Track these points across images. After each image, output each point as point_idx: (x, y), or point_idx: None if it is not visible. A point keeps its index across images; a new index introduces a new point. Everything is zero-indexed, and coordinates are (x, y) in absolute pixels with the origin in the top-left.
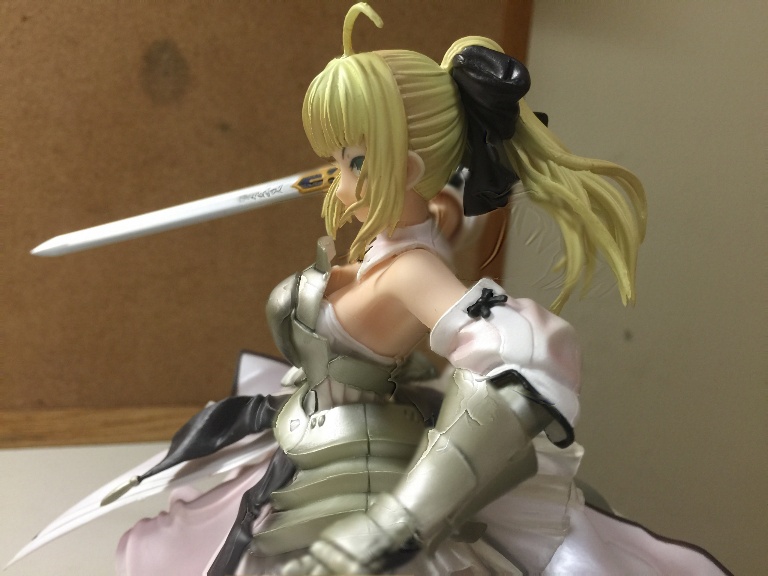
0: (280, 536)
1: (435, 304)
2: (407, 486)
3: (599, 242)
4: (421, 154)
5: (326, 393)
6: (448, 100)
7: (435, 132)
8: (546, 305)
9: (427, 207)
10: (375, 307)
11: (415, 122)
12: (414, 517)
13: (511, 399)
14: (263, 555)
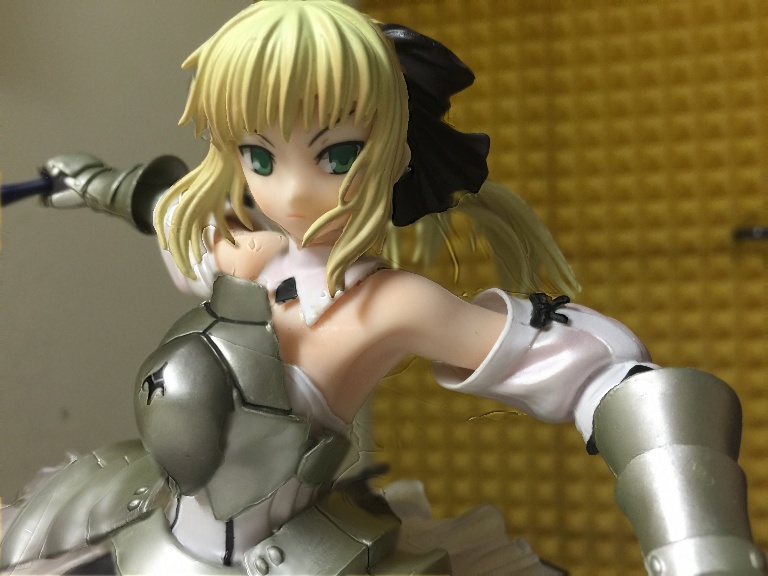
0: None
1: (473, 326)
2: None
3: (539, 240)
4: None
5: (260, 513)
6: None
7: None
8: None
9: None
10: (361, 354)
11: None
12: None
13: None
14: None
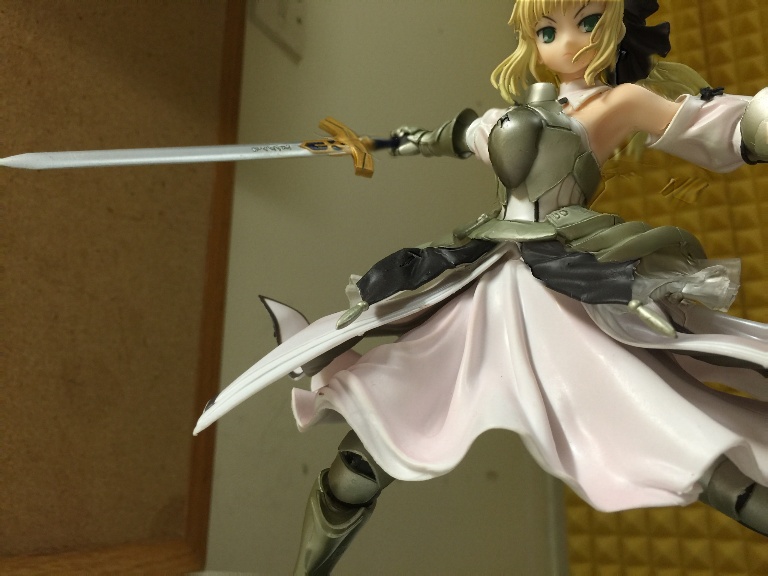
0: (633, 245)
1: (667, 103)
2: None
3: None
4: None
5: (553, 198)
6: None
7: None
8: None
9: None
10: (604, 119)
11: None
12: (690, 241)
13: (713, 167)
14: (625, 261)
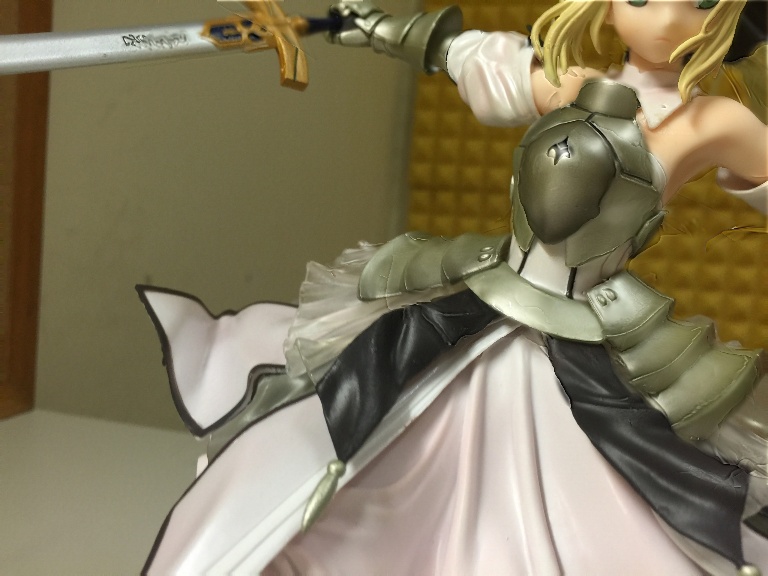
0: (718, 407)
1: None
2: None
3: None
4: None
5: (597, 265)
6: None
7: None
8: None
9: None
10: (689, 155)
11: None
12: None
13: None
14: (708, 435)
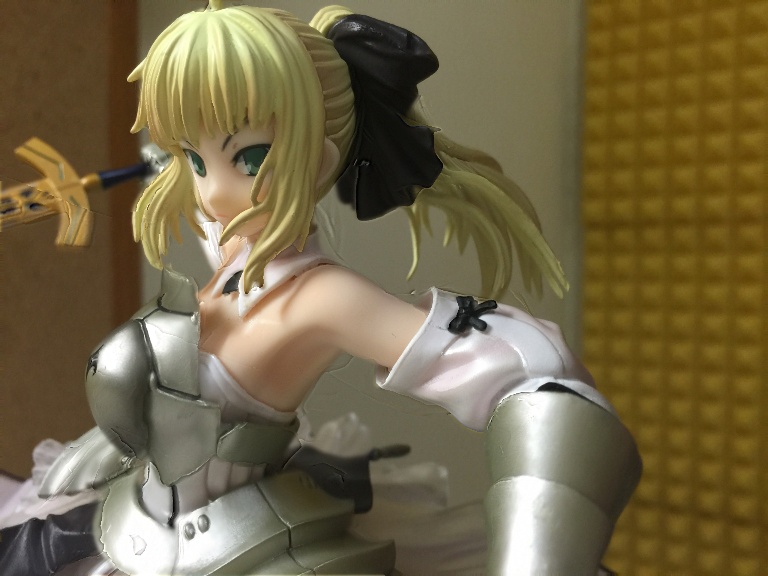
0: None
1: (390, 327)
2: (355, 572)
3: (525, 234)
4: (335, 141)
5: (197, 484)
6: (345, 76)
7: (343, 114)
8: (521, 306)
9: (315, 213)
10: (283, 348)
11: (328, 99)
12: None
13: None
14: None
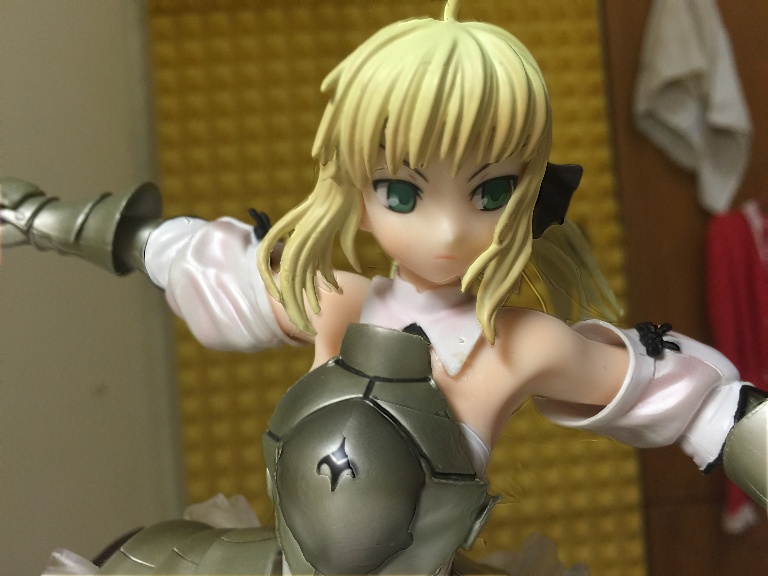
0: None
1: (601, 361)
2: None
3: (587, 267)
4: None
5: None
6: None
7: None
8: None
9: None
10: None
11: None
12: None
13: None
14: None
